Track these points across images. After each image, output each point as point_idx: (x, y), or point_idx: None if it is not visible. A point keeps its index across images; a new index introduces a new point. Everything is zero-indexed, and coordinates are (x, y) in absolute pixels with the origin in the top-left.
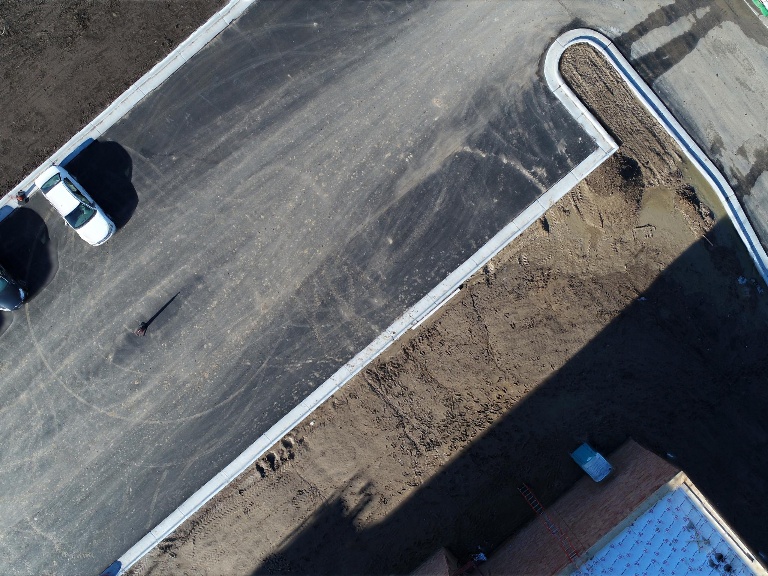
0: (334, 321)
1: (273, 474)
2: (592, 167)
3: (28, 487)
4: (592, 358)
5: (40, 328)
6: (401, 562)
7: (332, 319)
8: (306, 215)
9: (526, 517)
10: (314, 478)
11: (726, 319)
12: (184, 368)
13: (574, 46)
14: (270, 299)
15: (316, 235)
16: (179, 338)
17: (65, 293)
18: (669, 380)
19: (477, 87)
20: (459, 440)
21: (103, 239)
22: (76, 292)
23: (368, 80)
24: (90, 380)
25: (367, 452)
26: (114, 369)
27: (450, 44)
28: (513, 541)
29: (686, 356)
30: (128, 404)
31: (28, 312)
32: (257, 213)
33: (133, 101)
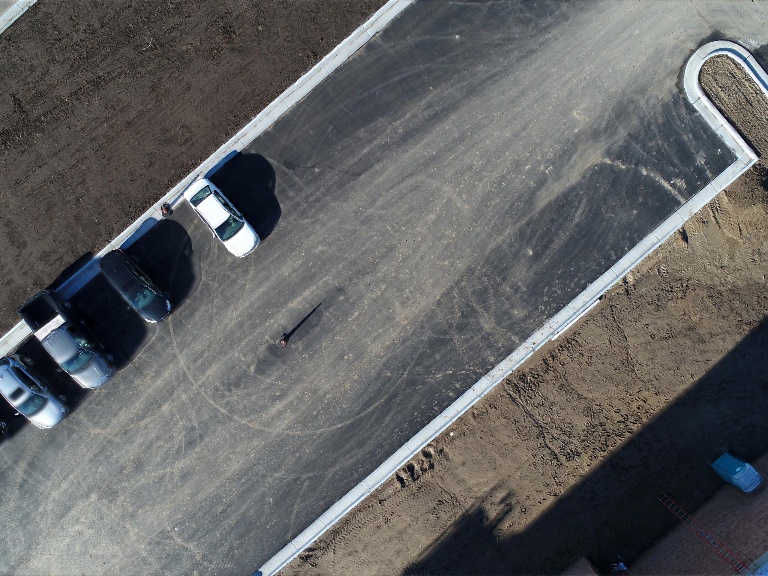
0: (474, 332)
1: (413, 484)
2: (731, 178)
3: (169, 497)
4: (732, 368)
5: (183, 339)
6: (541, 571)
7: (472, 330)
8: (447, 226)
9: (666, 527)
10: (454, 488)
11: None
12: (325, 379)
13: (713, 58)
14: (410, 310)
15: (456, 246)
16: (320, 349)
17: (208, 304)
18: None
19: (617, 99)
20: (599, 450)
21: (249, 251)
22: (219, 303)
23: (509, 92)
24: (232, 391)
25: (507, 462)
26: (256, 380)
27: (591, 56)
28: (655, 551)
29: None
30: (269, 415)
31: (171, 323)
32: (398, 225)
33: (277, 113)
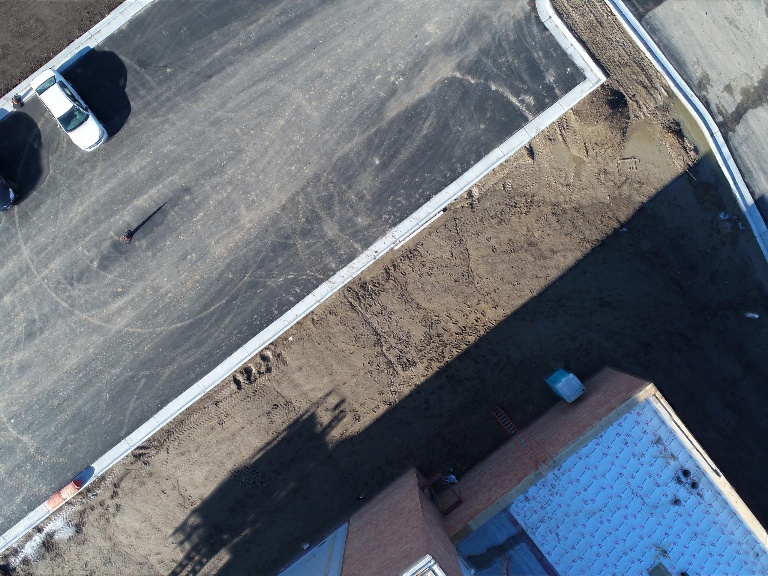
0: (317, 238)
1: (250, 387)
2: (579, 97)
3: (7, 388)
4: (571, 286)
5: (28, 231)
6: (373, 481)
7: (316, 236)
8: (295, 132)
9: (499, 441)
10: (290, 393)
11: (707, 254)
12: (167, 277)
13: None
14: (255, 213)
15: (304, 152)
16: (164, 247)
17: (54, 197)
18: (648, 311)
19: (469, 14)
20: (436, 361)
21: (94, 144)
22: (65, 197)
23: (362, 3)
24: (74, 285)
25: (344, 369)
26: (98, 275)
27: None
28: (485, 464)
29: (665, 289)
30: (110, 310)
31: (17, 214)
32: (247, 128)
33: (131, 12)
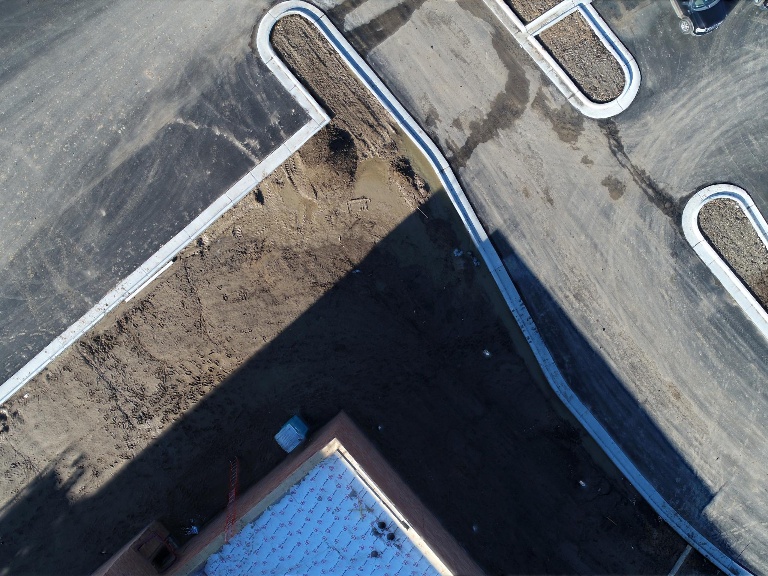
0: (47, 293)
1: None
2: (304, 139)
3: None
4: (304, 330)
5: None
6: (114, 535)
7: (45, 291)
8: (18, 187)
9: (238, 490)
10: (28, 451)
11: (442, 292)
12: None
13: (286, 18)
14: None
15: (29, 207)
16: None
17: None
18: (383, 353)
19: (189, 59)
20: (171, 413)
21: None
22: None
23: (79, 52)
24: None
25: (80, 425)
26: None
27: (161, 16)
28: (222, 514)
29: (401, 329)
30: None
31: None
32: None
33: None
